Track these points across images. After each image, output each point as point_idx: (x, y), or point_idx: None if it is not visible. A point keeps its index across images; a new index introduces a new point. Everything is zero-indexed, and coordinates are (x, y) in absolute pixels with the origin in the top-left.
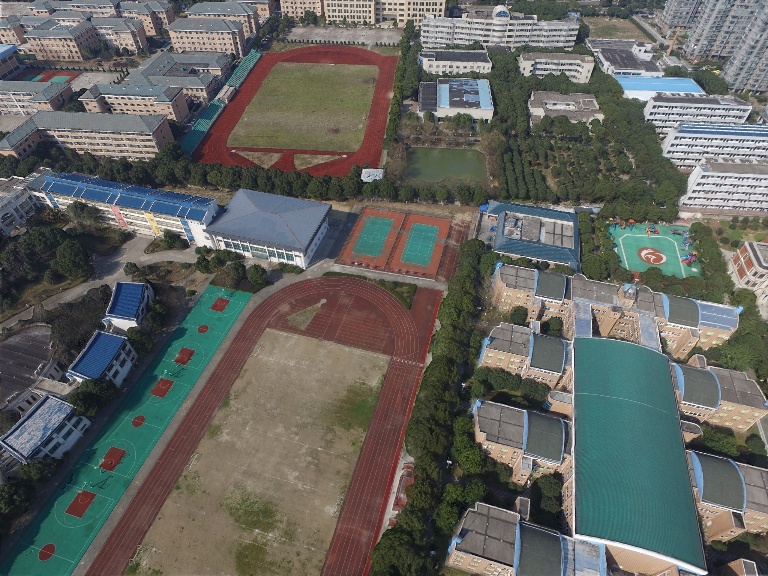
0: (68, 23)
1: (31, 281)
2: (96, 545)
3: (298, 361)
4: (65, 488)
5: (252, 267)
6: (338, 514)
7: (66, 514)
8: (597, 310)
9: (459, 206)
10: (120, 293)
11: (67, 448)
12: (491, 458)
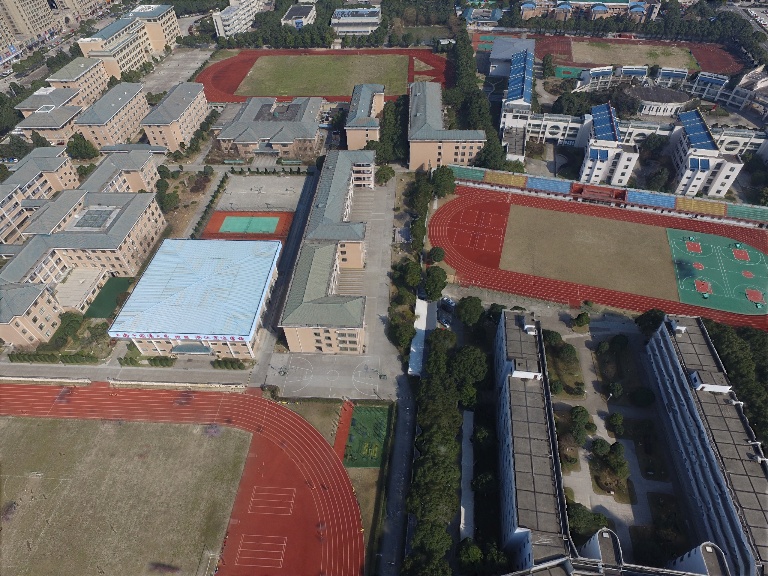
0: (75, 216)
1: None
2: None
3: None
4: None
5: None
6: None
7: None
8: None
9: None
10: None
11: None
12: None
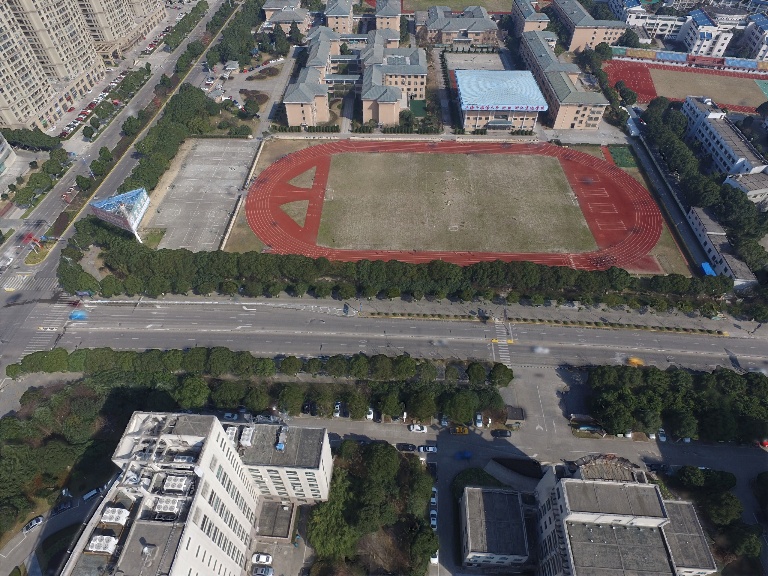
0: (384, 59)
1: None
2: None
3: None
4: None
5: None
6: None
7: None
8: None
9: None
10: None
11: None
12: None
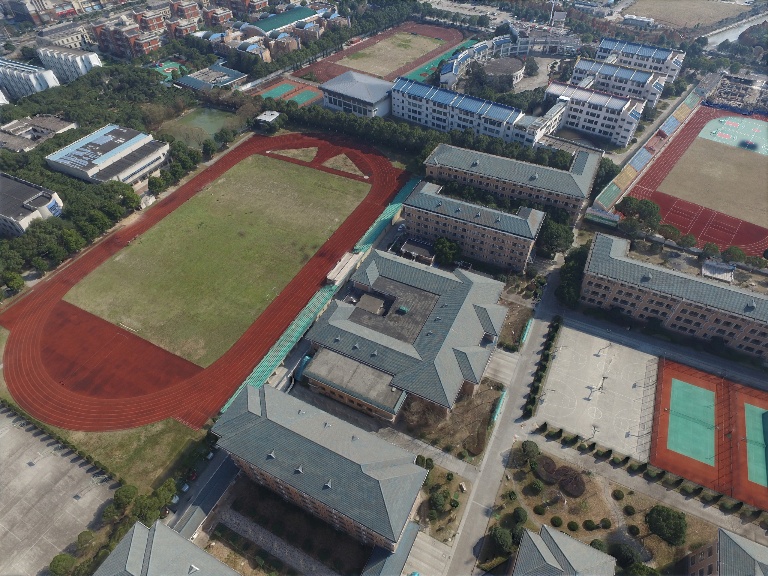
0: None
1: None
2: None
3: None
4: None
5: None
6: None
7: None
8: None
9: None
10: None
11: None
12: None
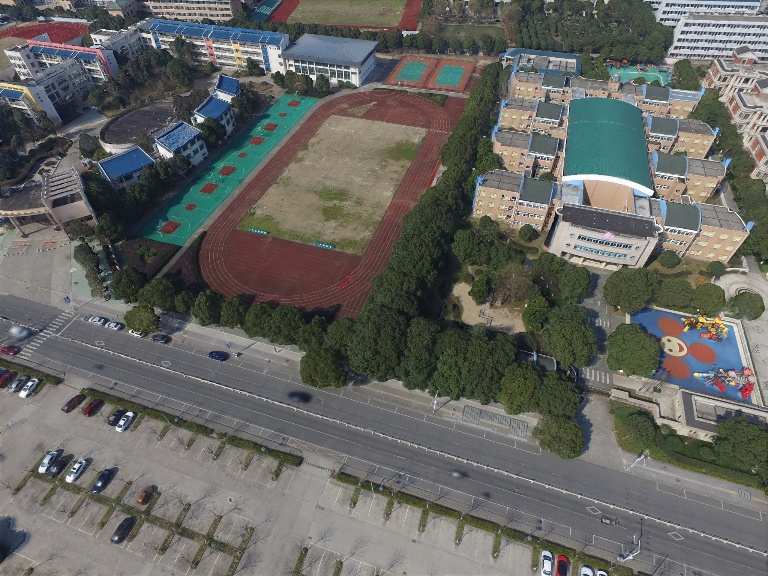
0: None
1: (147, 89)
2: (224, 205)
3: (357, 130)
4: (196, 182)
5: (319, 75)
6: (393, 195)
7: (200, 192)
8: (590, 95)
9: (482, 56)
10: (223, 81)
11: (194, 164)
12: (505, 167)
